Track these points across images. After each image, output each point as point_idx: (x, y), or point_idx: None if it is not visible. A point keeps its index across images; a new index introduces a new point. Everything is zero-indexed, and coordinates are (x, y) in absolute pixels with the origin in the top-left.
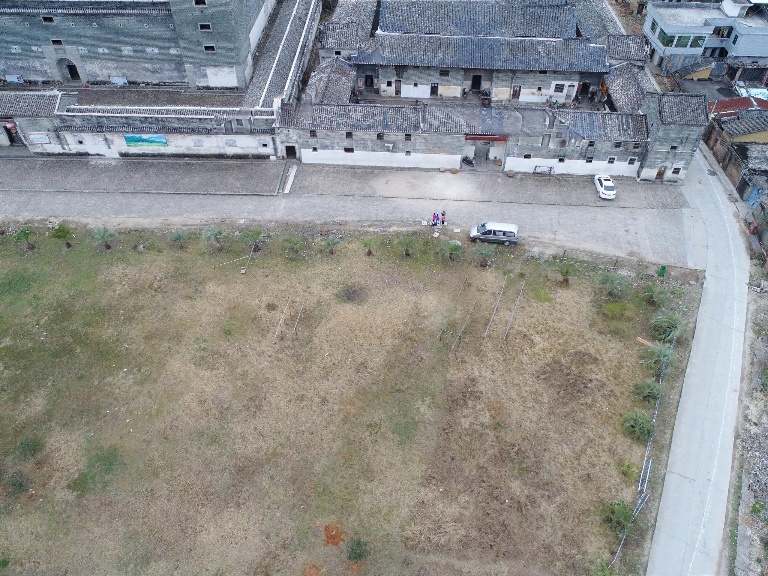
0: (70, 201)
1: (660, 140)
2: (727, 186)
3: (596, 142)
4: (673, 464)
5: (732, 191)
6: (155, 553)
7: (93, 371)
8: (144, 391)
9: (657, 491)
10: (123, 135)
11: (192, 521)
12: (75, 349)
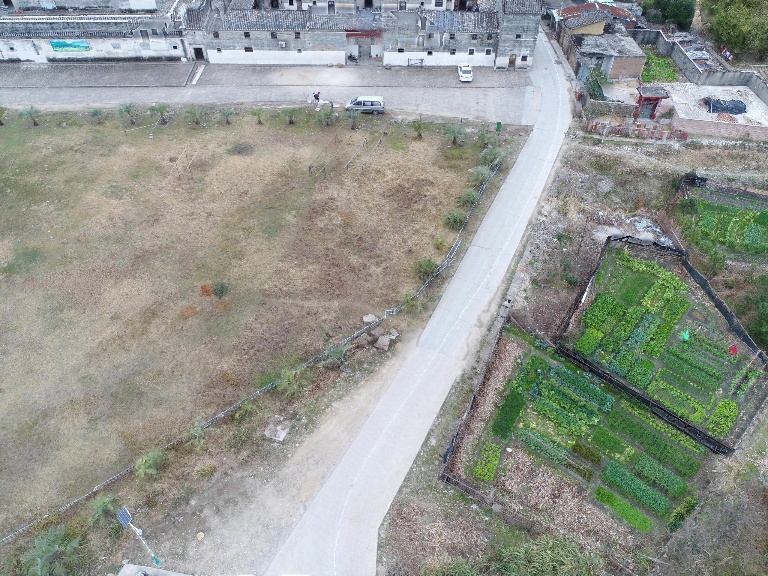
0: (3, 94)
1: (506, 29)
2: (568, 71)
3: (456, 35)
4: (476, 241)
5: (571, 74)
6: (67, 305)
7: (21, 203)
8: (63, 214)
9: (460, 257)
10: (49, 41)
11: (97, 287)
12: (6, 190)
